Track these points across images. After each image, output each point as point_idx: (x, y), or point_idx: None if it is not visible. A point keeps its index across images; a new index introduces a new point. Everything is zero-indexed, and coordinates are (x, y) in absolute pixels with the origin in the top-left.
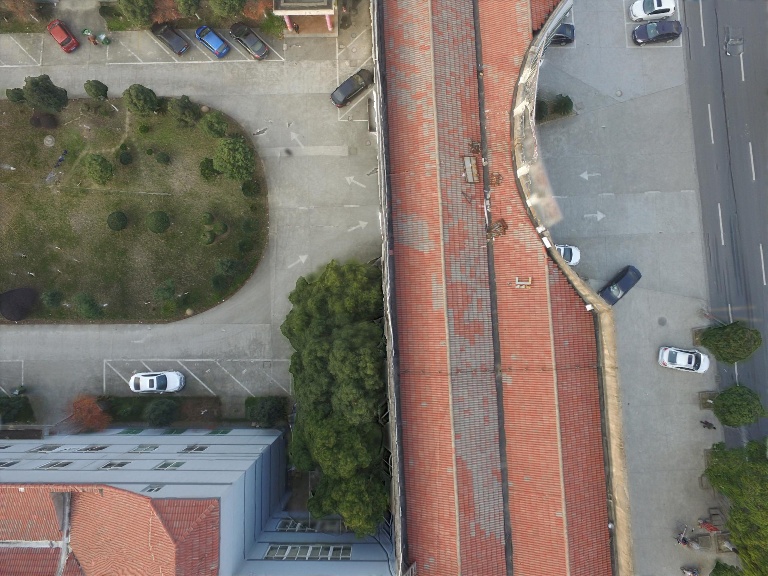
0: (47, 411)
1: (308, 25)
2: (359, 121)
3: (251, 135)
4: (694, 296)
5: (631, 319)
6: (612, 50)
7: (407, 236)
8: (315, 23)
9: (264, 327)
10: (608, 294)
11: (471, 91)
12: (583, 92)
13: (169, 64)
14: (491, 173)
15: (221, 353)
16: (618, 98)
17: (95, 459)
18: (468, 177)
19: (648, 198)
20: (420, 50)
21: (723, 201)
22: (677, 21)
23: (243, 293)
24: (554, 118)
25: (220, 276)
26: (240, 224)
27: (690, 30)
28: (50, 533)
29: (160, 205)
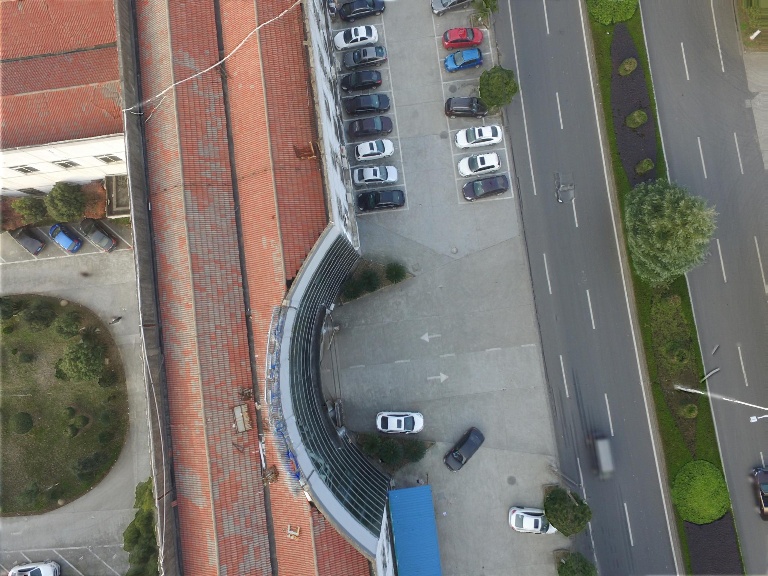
0: None
1: None
2: None
3: (107, 324)
4: (542, 452)
5: (480, 480)
6: (444, 208)
7: (186, 489)
8: None
9: (130, 512)
10: (452, 460)
11: (240, 338)
12: (418, 253)
13: (29, 262)
14: (263, 418)
15: (92, 540)
16: (454, 256)
17: None
18: (239, 427)
19: (489, 355)
20: (185, 307)
21: (564, 353)
22: (503, 176)
23: (109, 480)
24: (391, 283)
25: None
26: (101, 413)
27: (520, 180)
28: None
29: (28, 401)
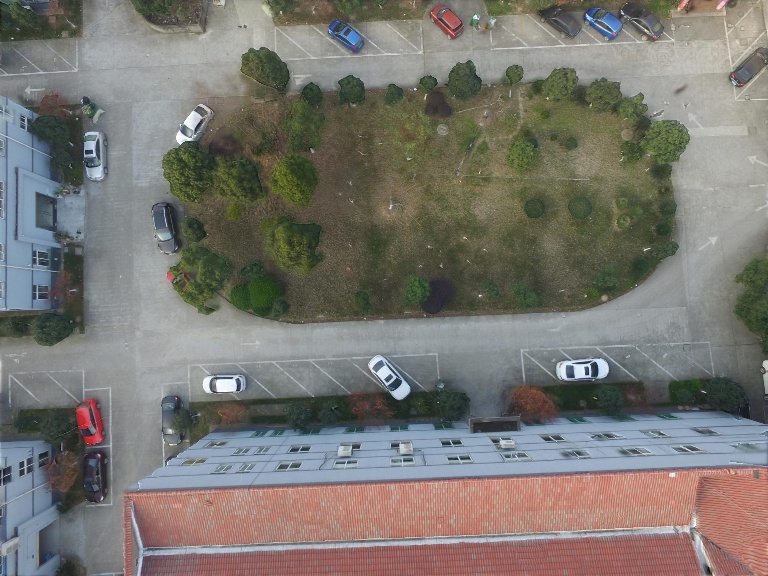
0: (471, 404)
1: (695, 4)
2: (756, 100)
3: (648, 117)
4: None
5: None
6: None
7: None
8: (705, 2)
9: (680, 310)
10: None
11: None
12: None
13: (556, 48)
14: None
15: (640, 338)
16: None
17: (652, 444)
18: None
19: None
20: None
21: None
22: None
23: (656, 277)
24: None
25: (642, 260)
26: (648, 208)
27: None
28: (680, 518)
29: (566, 191)
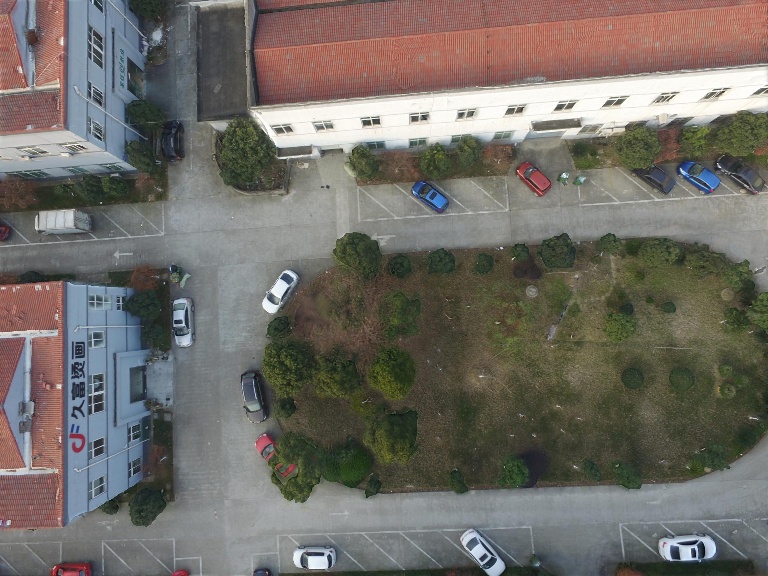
0: None
1: None
2: None
3: None
4: None
5: None
6: None
7: None
8: None
9: None
10: None
11: None
12: None
13: (649, 202)
14: None
15: (747, 512)
16: None
17: None
18: None
19: None
20: None
21: None
22: None
23: (763, 446)
24: None
25: (749, 432)
26: (753, 372)
27: None
28: None
29: (663, 356)
